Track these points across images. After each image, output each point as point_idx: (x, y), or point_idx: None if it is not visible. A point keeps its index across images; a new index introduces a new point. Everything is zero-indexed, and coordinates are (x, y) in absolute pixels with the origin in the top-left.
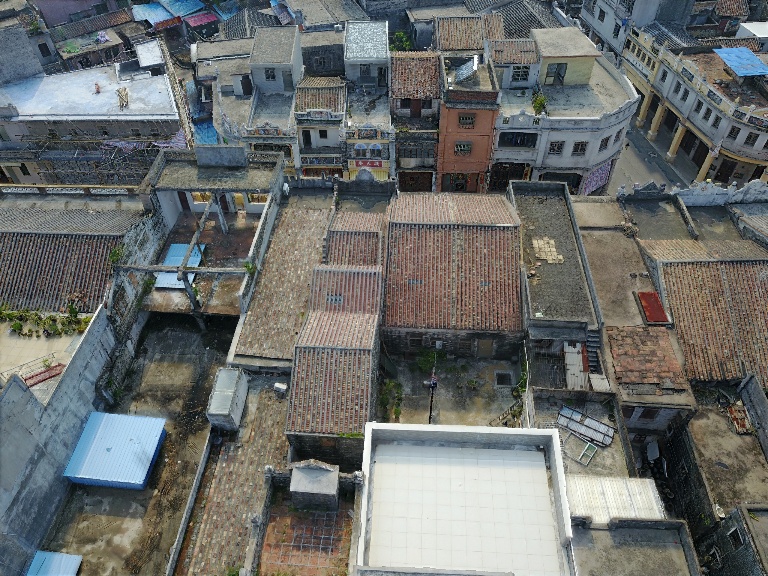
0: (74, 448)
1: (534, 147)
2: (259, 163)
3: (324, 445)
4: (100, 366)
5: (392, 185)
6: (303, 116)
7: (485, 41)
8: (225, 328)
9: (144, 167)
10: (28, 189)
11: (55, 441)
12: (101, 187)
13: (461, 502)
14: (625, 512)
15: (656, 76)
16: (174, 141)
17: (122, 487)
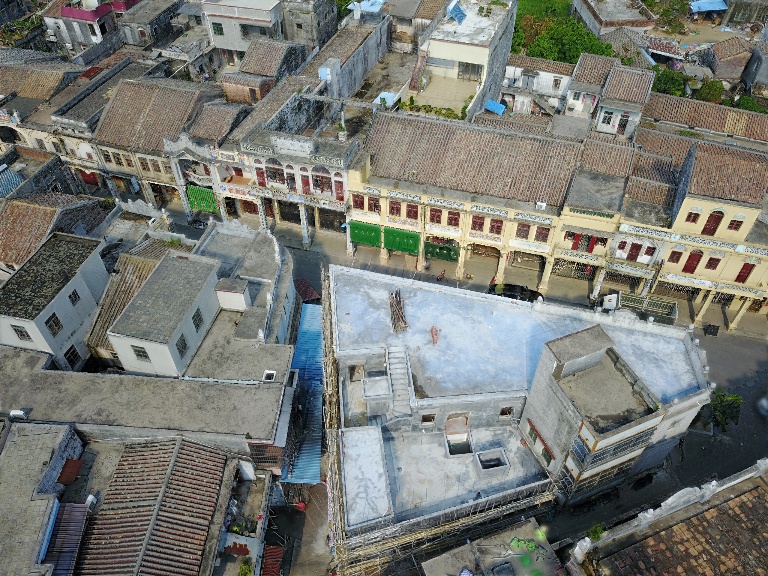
0: None
1: None
2: None
3: None
4: None
5: None
6: None
7: None
8: None
9: None
10: (481, 208)
11: None
12: (409, 192)
13: (249, 5)
14: None
15: None
16: None
17: None
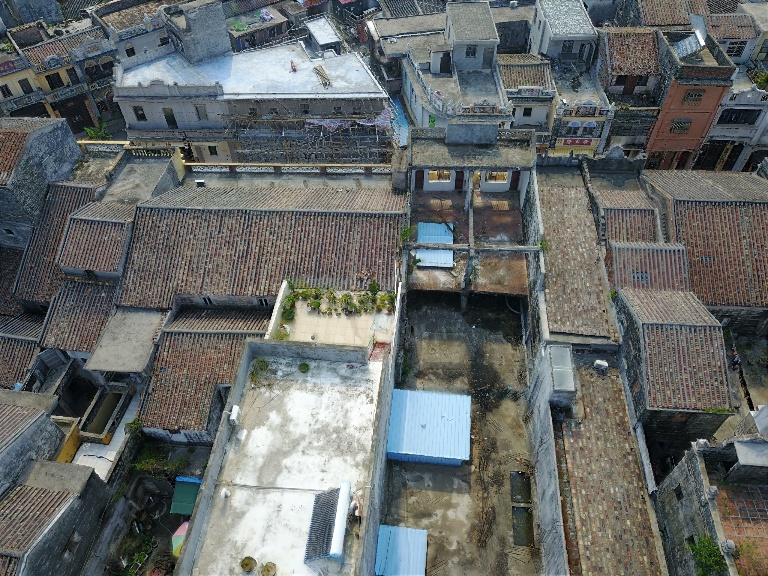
0: (389, 425)
1: (752, 124)
2: (506, 141)
3: (673, 421)
4: (396, 344)
5: (641, 163)
6: (513, 94)
7: (694, 16)
8: (483, 307)
9: (345, 146)
10: (263, 168)
11: (387, 418)
12: (339, 166)
13: None
14: None
15: None
16: (379, 120)
17: (440, 463)
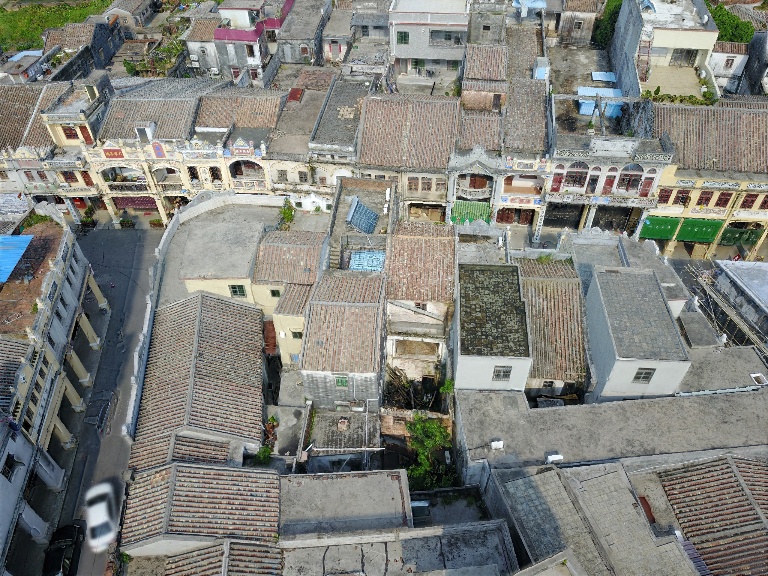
0: None
1: None
2: None
3: None
4: None
5: None
6: None
7: None
8: None
9: None
10: None
11: None
12: (728, 180)
13: None
14: (367, 17)
15: (54, 356)
16: None
17: None
